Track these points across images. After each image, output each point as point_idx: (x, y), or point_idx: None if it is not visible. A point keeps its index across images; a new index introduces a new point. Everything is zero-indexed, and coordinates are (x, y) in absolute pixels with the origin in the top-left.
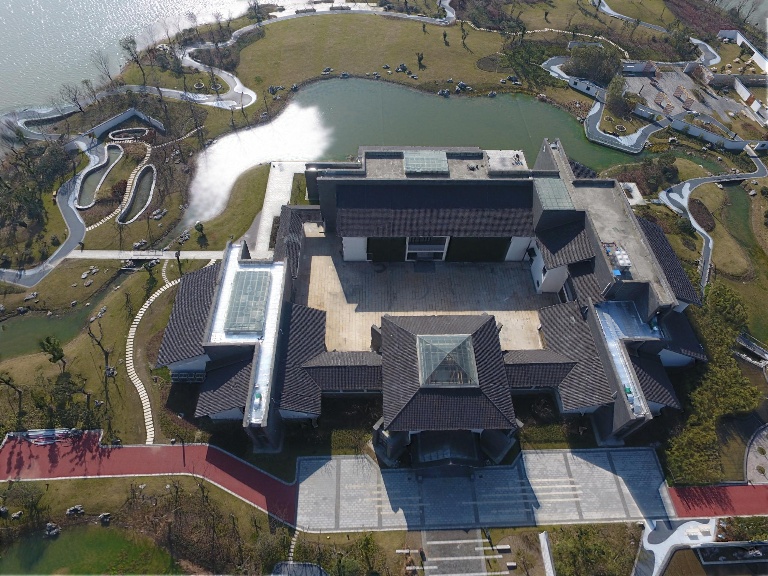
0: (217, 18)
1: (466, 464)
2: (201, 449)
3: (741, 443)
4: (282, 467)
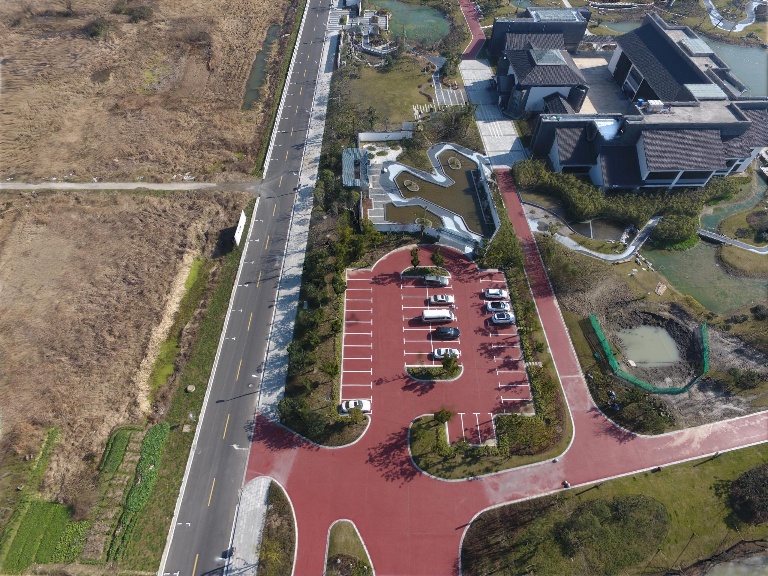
0: None
1: (498, 84)
2: (483, 38)
3: (549, 208)
4: (482, 56)
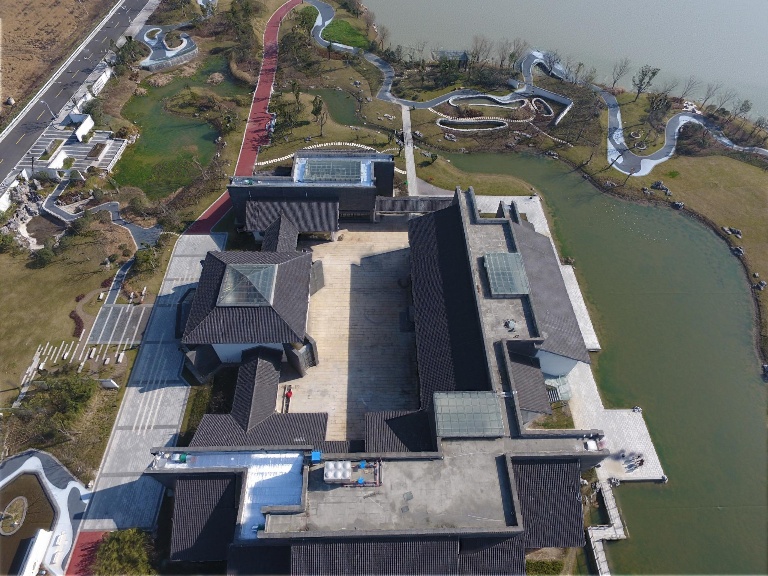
0: (758, 122)
1: (177, 318)
2: None
3: None
4: (224, 225)
